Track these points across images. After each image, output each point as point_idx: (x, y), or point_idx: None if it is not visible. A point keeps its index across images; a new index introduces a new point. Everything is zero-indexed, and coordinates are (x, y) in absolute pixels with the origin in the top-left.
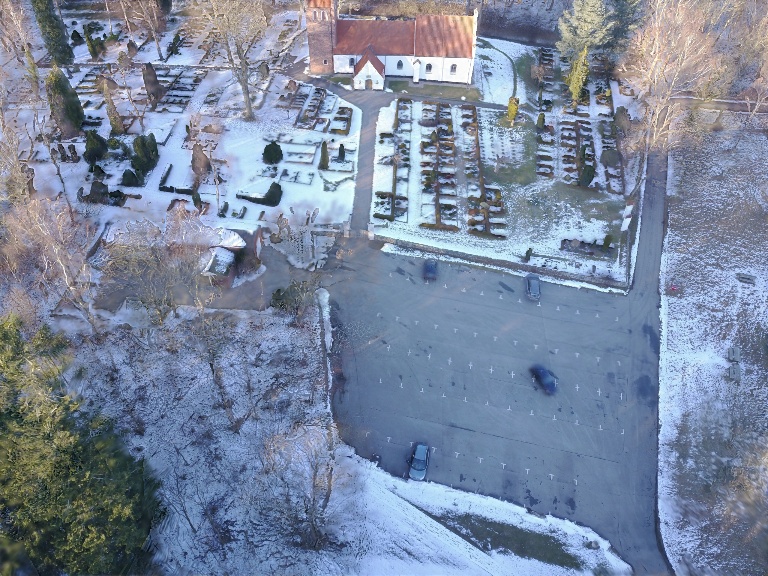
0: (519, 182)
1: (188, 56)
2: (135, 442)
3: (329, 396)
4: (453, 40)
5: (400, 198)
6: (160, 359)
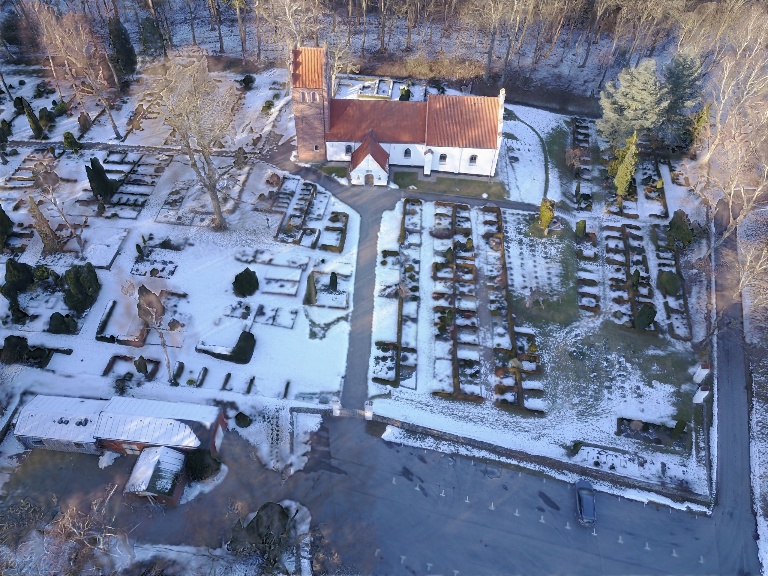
0: (558, 322)
1: (152, 132)
2: None
3: None
4: (474, 126)
5: (407, 350)
6: None
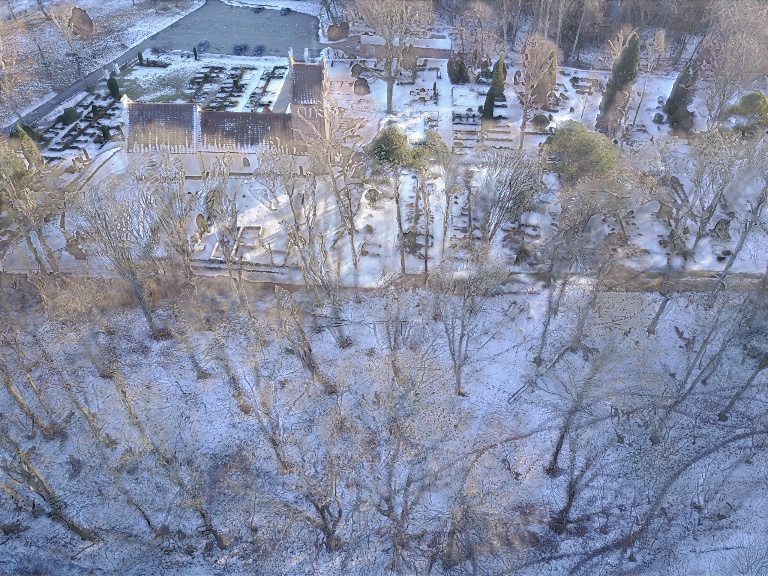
0: None
1: None
2: None
3: None
4: None
5: None
6: None
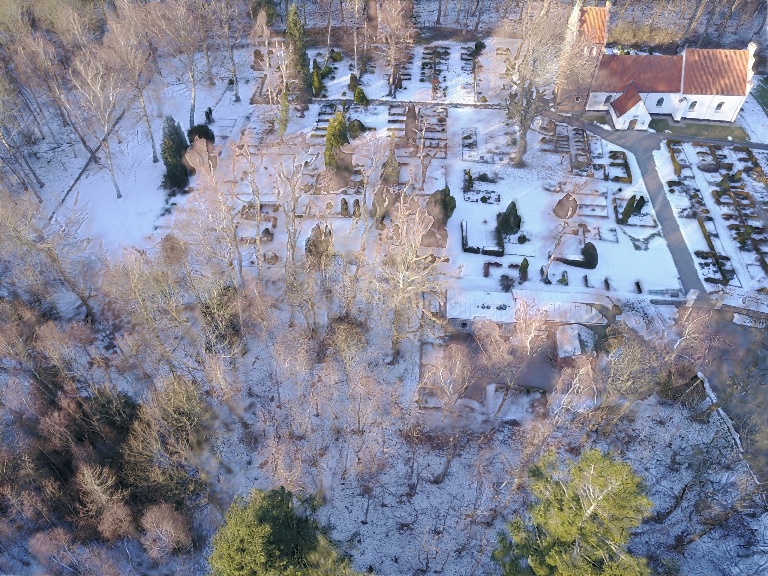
0: None
1: (414, 91)
2: None
3: None
4: (725, 76)
5: (722, 258)
6: (562, 462)
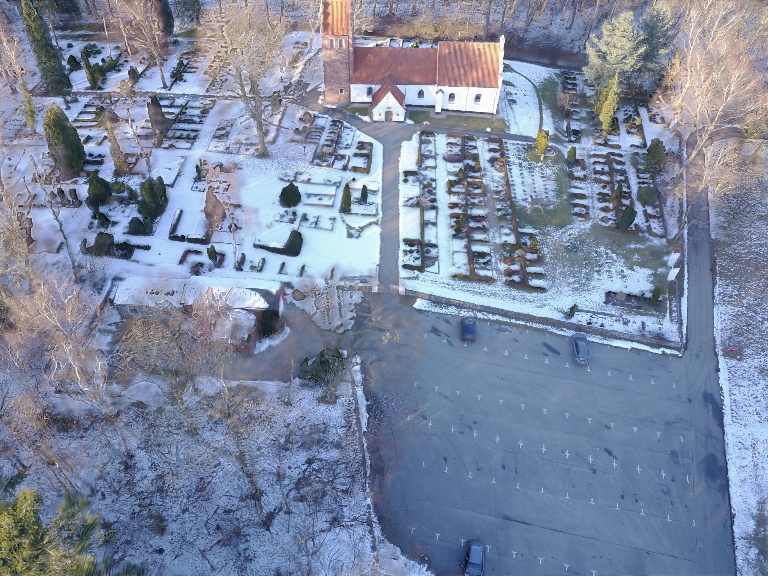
0: (554, 225)
1: (193, 83)
2: (154, 544)
3: (368, 484)
4: (478, 69)
5: (429, 245)
6: None
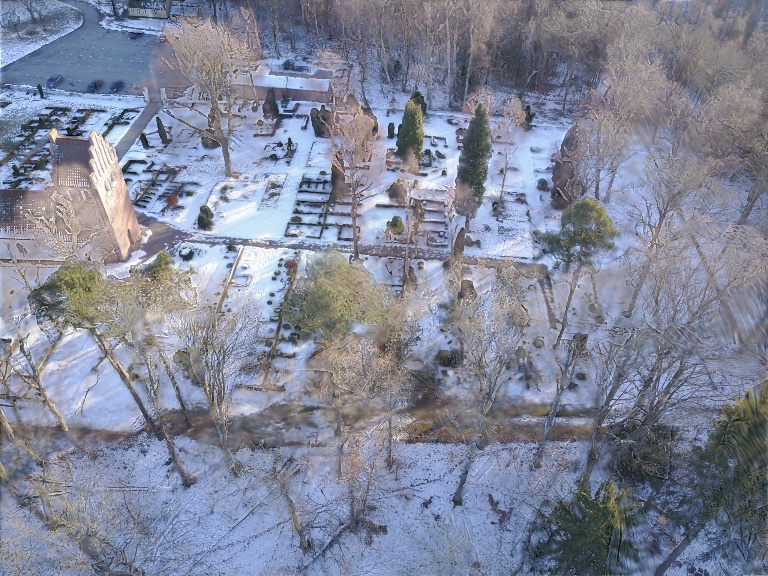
0: None
1: None
2: None
3: None
4: None
5: None
6: None
